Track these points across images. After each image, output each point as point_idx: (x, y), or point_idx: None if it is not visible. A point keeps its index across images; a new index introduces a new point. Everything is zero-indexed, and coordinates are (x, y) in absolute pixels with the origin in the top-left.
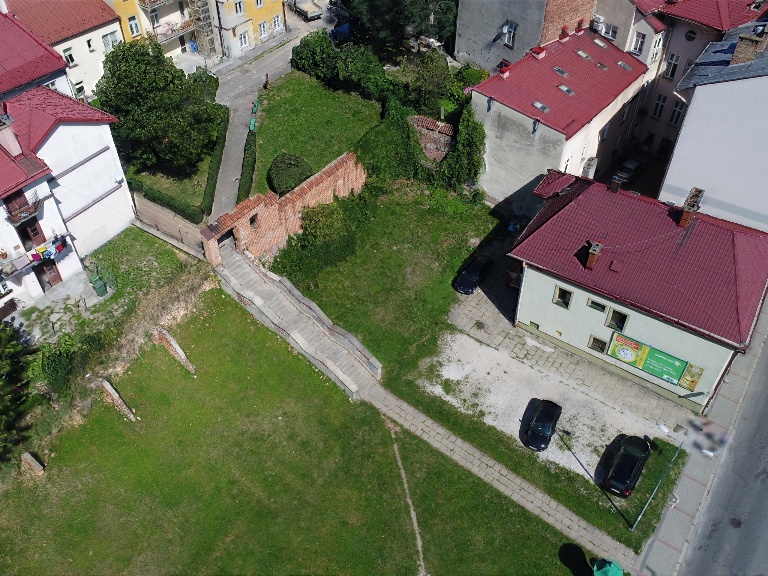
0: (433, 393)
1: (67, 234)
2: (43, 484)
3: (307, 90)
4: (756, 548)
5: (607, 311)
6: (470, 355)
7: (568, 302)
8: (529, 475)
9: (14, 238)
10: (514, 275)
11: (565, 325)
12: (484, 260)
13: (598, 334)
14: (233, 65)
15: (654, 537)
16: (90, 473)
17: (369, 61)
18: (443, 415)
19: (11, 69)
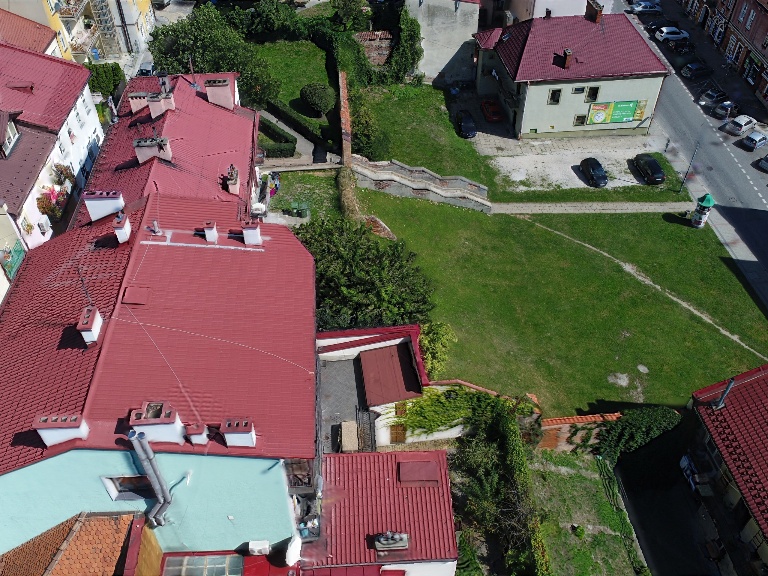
0: (522, 191)
1: (261, 177)
2: None
3: None
4: (728, 173)
5: (586, 91)
6: (515, 164)
7: (558, 99)
8: (613, 199)
9: None
10: (513, 100)
11: (557, 118)
12: (466, 112)
13: (580, 112)
14: (148, 57)
15: (690, 191)
16: None
17: (287, 8)
18: (541, 197)
19: (55, 86)
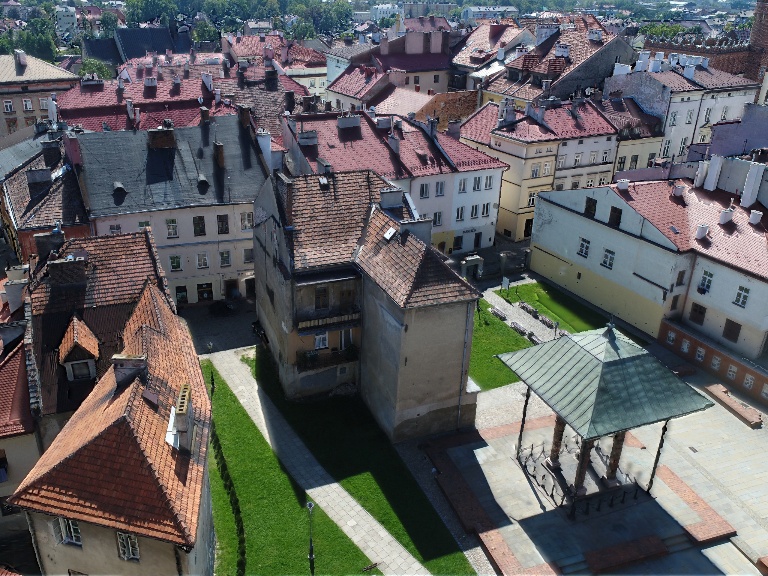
0: None
1: None
2: None
3: None
4: None
5: None
6: None
7: None
8: None
9: None
10: None
11: None
12: None
13: None
14: None
15: None
16: None
17: None
18: None
19: None
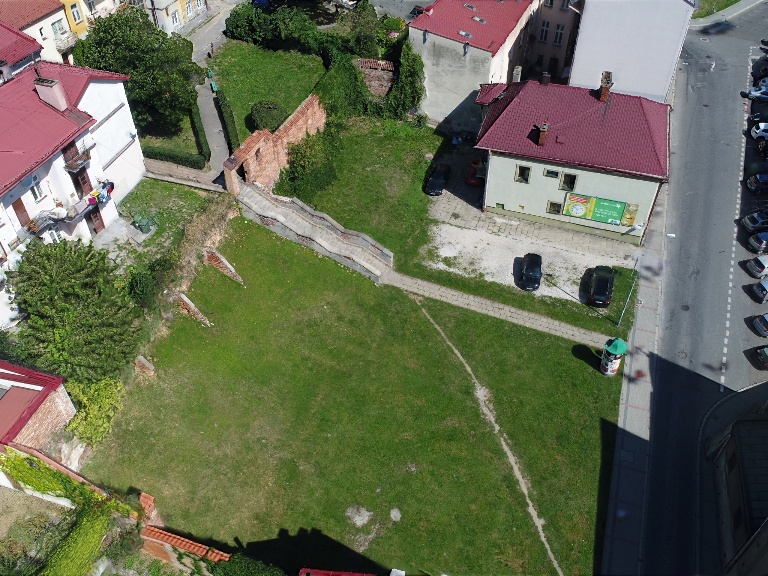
0: (439, 268)
1: None
2: (156, 382)
3: (249, 54)
4: (704, 320)
5: (560, 176)
6: (457, 237)
7: (527, 177)
8: (532, 308)
9: (70, 186)
10: (479, 167)
11: (526, 198)
12: (444, 167)
13: (554, 199)
14: None
15: (634, 328)
16: (190, 370)
17: (304, 20)
18: (452, 282)
19: None
